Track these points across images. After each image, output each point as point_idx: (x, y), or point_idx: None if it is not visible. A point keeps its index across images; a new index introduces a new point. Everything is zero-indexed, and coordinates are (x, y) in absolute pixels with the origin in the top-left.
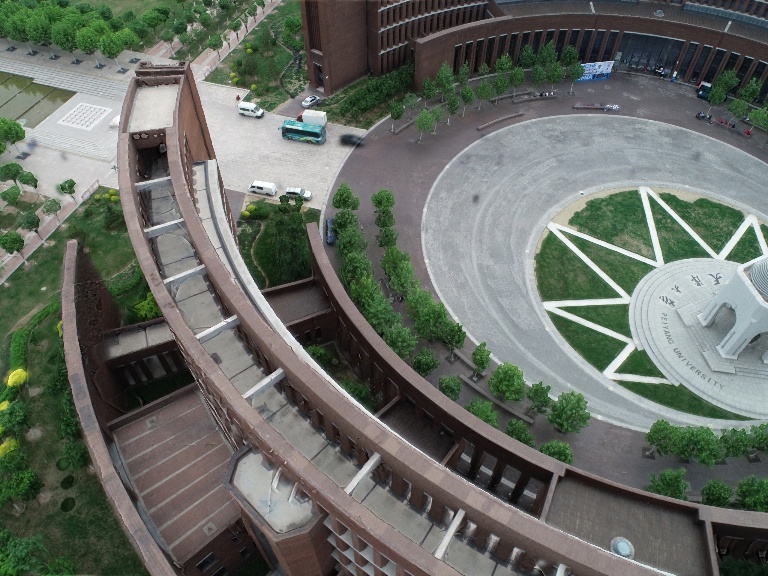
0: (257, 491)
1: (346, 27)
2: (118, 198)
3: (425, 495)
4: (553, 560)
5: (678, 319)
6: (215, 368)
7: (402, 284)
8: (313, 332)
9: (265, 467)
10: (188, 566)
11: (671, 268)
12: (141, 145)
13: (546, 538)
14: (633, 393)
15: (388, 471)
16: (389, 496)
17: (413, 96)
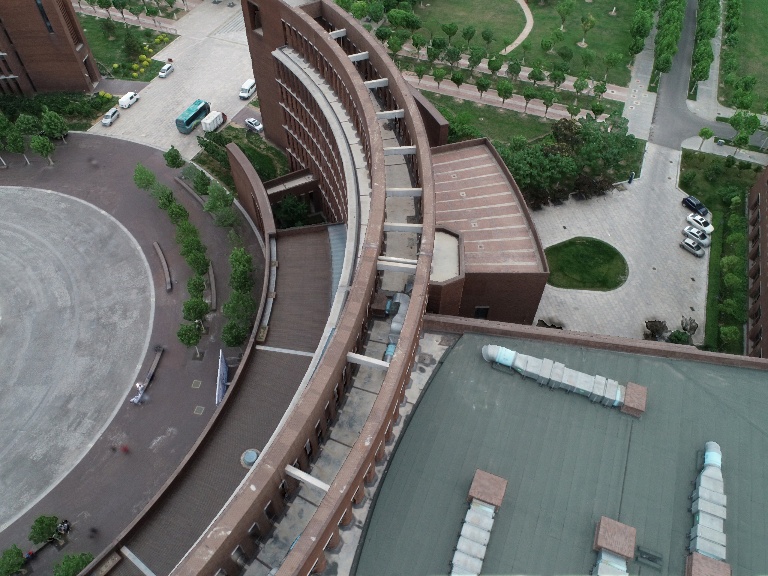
0: None
1: None
2: (157, 42)
3: None
4: None
5: None
6: None
7: None
8: None
9: None
10: None
11: None
12: None
13: None
14: None
15: None
16: None
17: None
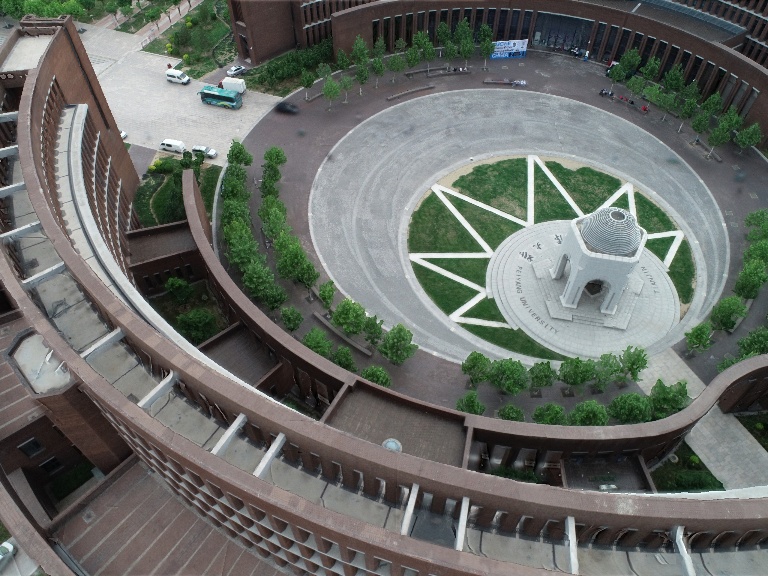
0: (31, 363)
1: (268, 0)
2: None
3: (159, 365)
4: (232, 409)
5: (532, 272)
6: (0, 256)
7: (271, 229)
8: (183, 269)
9: (44, 345)
10: (3, 443)
11: (538, 228)
12: (9, 85)
13: (226, 389)
14: (472, 334)
15: (131, 344)
16: (145, 372)
17: (326, 66)
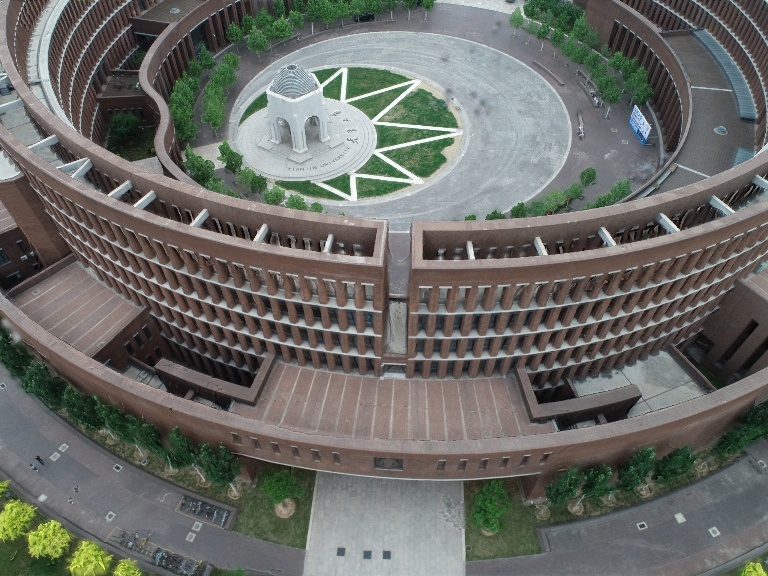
0: None
1: None
2: None
3: None
4: None
5: None
6: None
7: None
8: None
9: None
10: None
11: (368, 124)
12: None
13: None
14: None
15: None
16: None
17: None
